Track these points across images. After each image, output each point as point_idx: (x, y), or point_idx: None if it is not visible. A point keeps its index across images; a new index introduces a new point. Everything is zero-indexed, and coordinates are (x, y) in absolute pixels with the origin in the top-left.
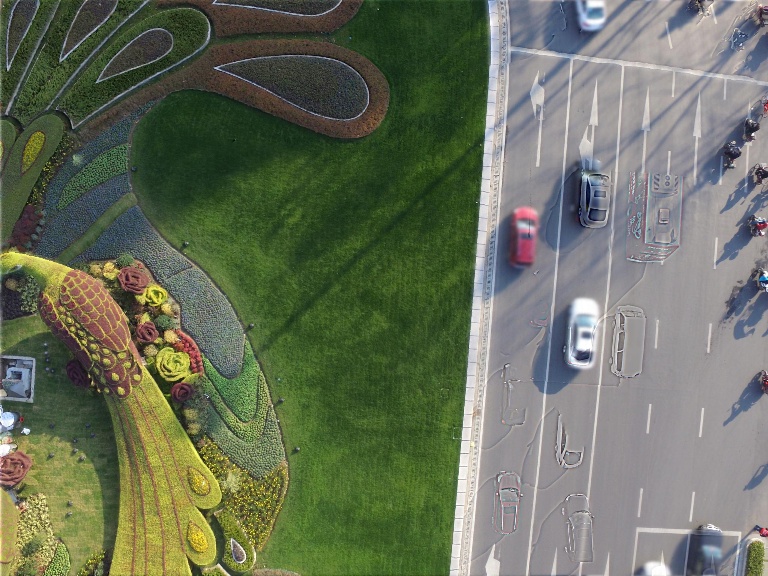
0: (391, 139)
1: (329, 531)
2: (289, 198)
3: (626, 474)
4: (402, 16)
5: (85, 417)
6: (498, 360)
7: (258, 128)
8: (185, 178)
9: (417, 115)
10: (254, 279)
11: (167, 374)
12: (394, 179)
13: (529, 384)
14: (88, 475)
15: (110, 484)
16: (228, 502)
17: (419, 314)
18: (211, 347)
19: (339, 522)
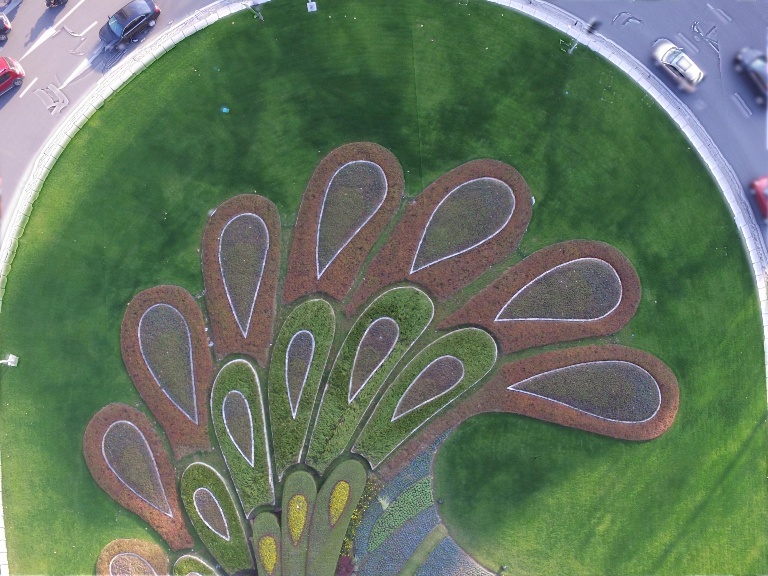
0: (685, 431)
1: None
2: (597, 506)
3: None
4: (679, 306)
5: None
6: None
7: (558, 442)
8: (493, 502)
9: (706, 403)
10: None
11: None
12: (693, 471)
13: None
14: None
15: None
16: None
17: None
18: None
19: None
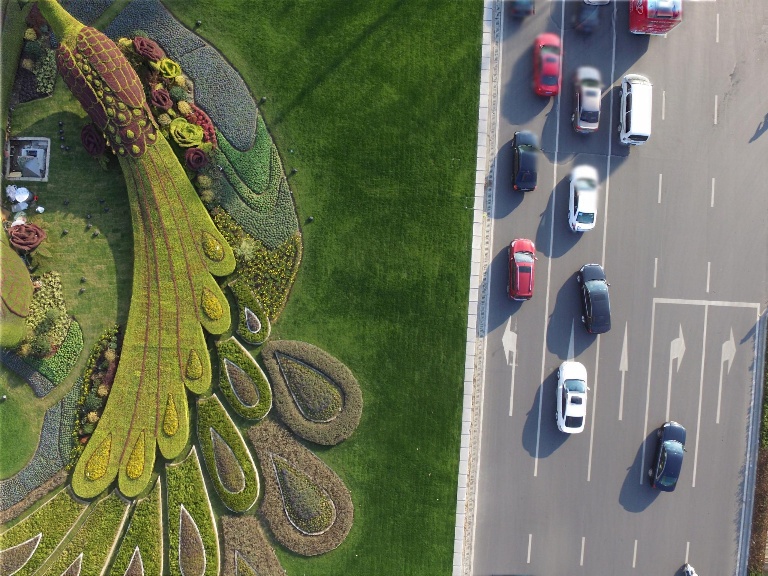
0: None
1: (344, 301)
2: None
3: (640, 243)
4: None
5: (99, 193)
6: (508, 132)
7: None
8: None
9: None
10: (266, 55)
11: (181, 140)
12: None
13: (539, 154)
14: (102, 250)
15: (124, 259)
16: (242, 271)
17: (428, 86)
18: (224, 120)
19: (354, 291)
